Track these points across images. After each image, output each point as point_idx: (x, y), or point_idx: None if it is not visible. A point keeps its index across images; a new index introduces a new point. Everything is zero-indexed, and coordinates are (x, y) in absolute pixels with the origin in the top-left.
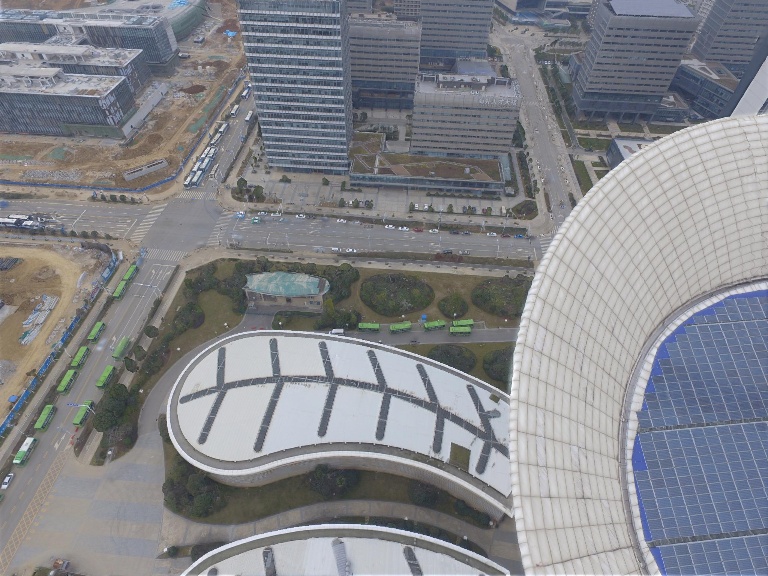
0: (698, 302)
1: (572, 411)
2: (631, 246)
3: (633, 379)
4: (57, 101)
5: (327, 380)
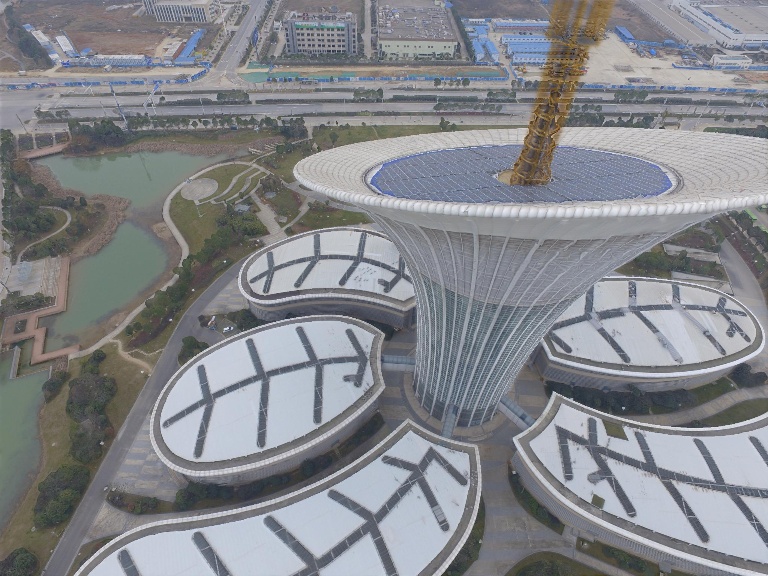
0: None
1: None
2: None
3: (679, 178)
4: None
5: None
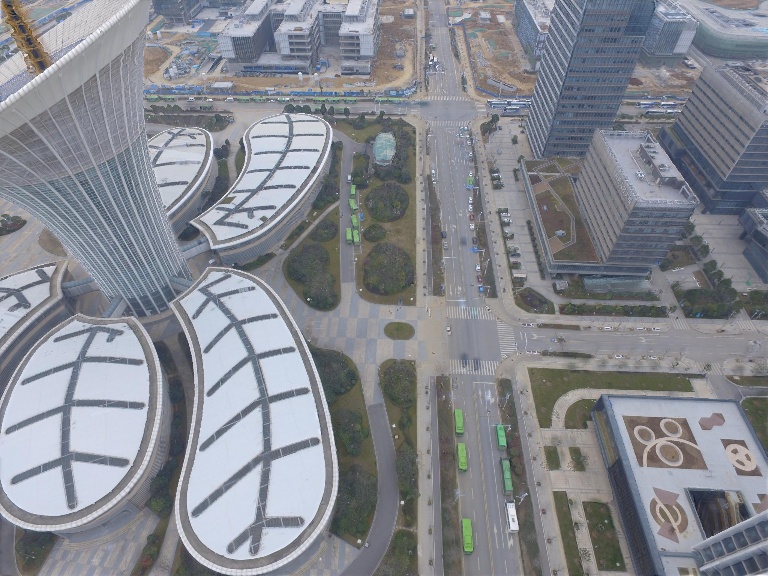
0: None
1: None
2: None
3: None
4: (532, 25)
5: (286, 150)
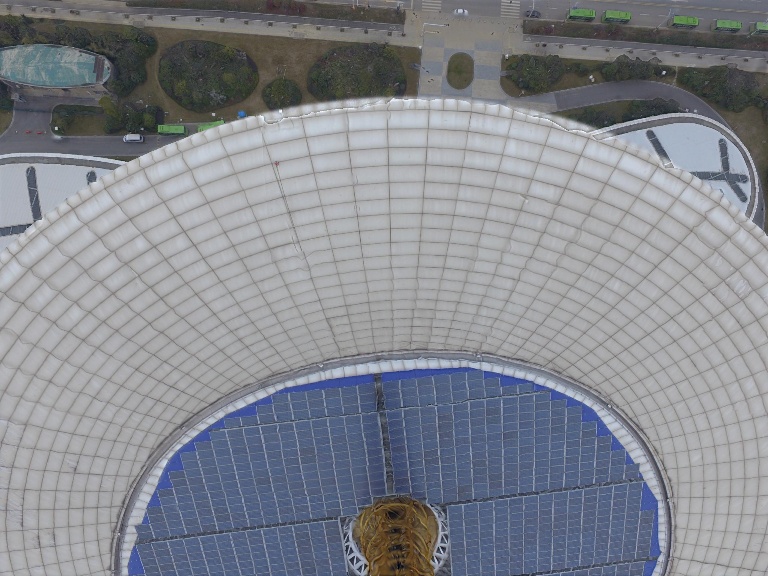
0: (237, 398)
1: (15, 564)
2: (71, 378)
3: (134, 494)
4: None
5: None
